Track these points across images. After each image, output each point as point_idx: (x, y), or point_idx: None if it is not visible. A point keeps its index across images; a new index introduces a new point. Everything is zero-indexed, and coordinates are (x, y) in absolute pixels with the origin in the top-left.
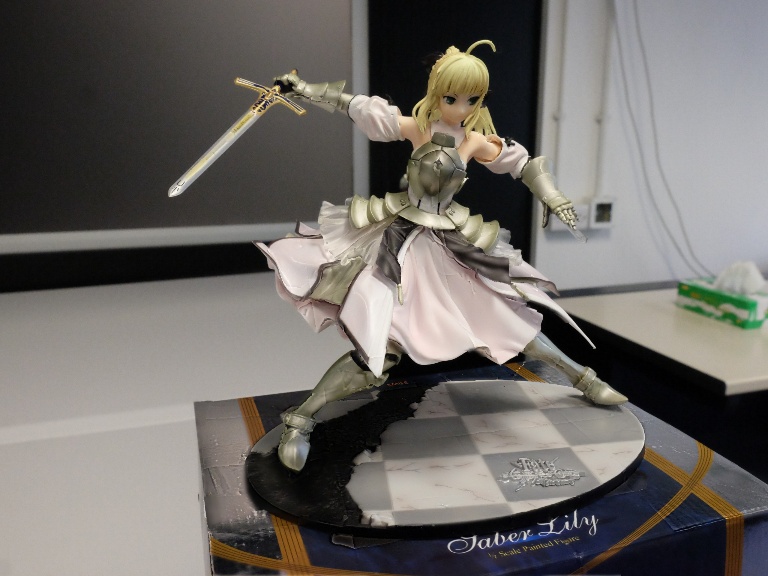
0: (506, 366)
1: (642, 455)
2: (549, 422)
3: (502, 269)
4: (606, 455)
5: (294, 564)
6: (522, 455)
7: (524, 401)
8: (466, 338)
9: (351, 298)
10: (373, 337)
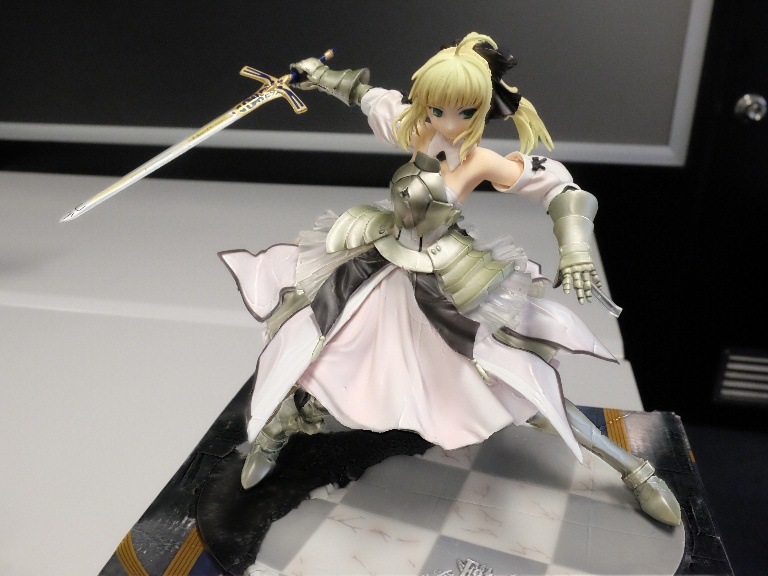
0: (603, 411)
1: None
2: (561, 517)
3: (465, 337)
4: None
5: None
6: (482, 553)
7: (562, 474)
8: (397, 413)
9: (275, 339)
10: (266, 394)
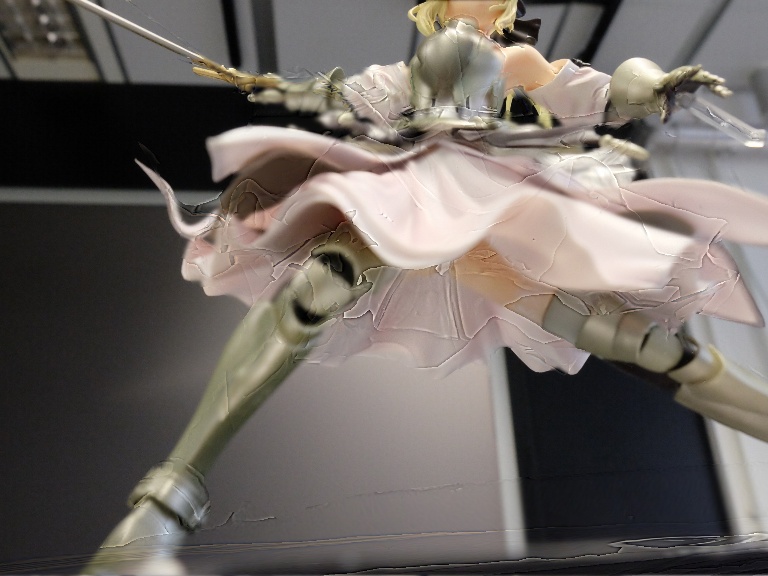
0: None
1: None
2: None
3: None
4: None
5: None
6: None
7: None
8: None
9: None
10: None
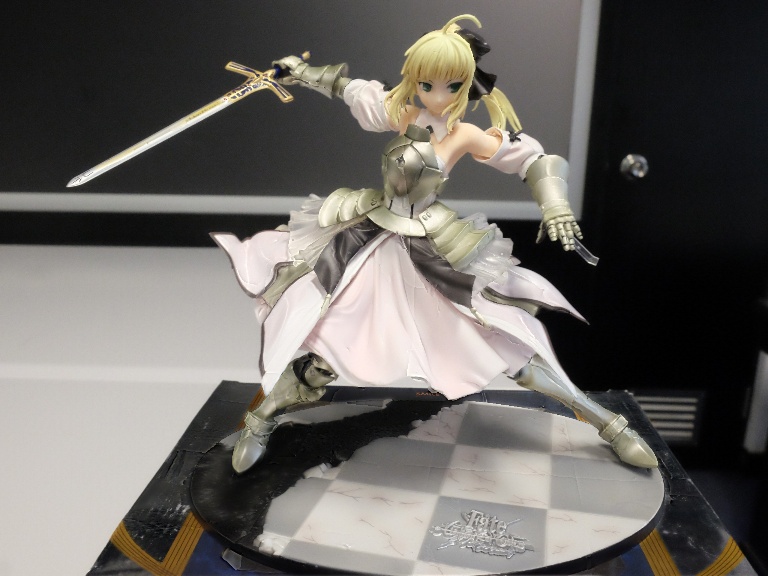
0: None
1: (639, 539)
2: (549, 472)
3: (463, 289)
4: (583, 530)
5: (167, 570)
6: (484, 506)
7: (541, 440)
8: (403, 364)
9: (279, 304)
10: (277, 350)
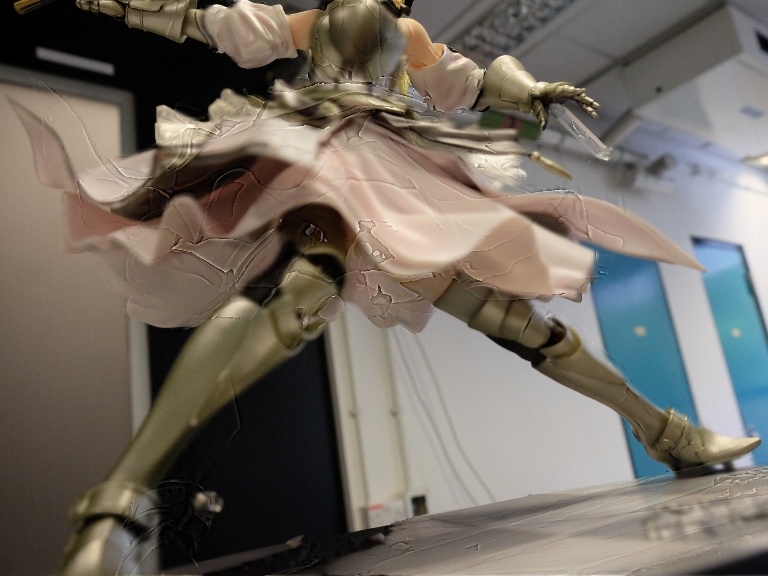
0: None
1: None
2: (672, 481)
3: (530, 127)
4: None
5: None
6: None
7: None
8: None
9: (279, 96)
10: None
